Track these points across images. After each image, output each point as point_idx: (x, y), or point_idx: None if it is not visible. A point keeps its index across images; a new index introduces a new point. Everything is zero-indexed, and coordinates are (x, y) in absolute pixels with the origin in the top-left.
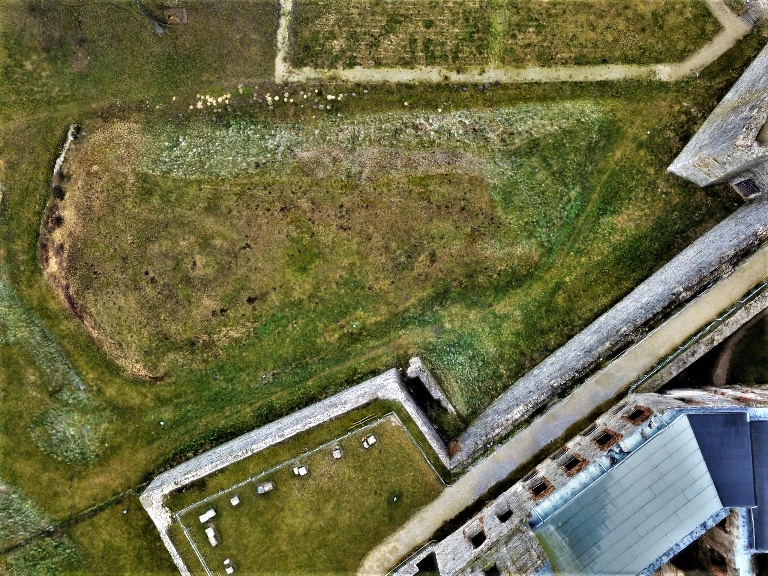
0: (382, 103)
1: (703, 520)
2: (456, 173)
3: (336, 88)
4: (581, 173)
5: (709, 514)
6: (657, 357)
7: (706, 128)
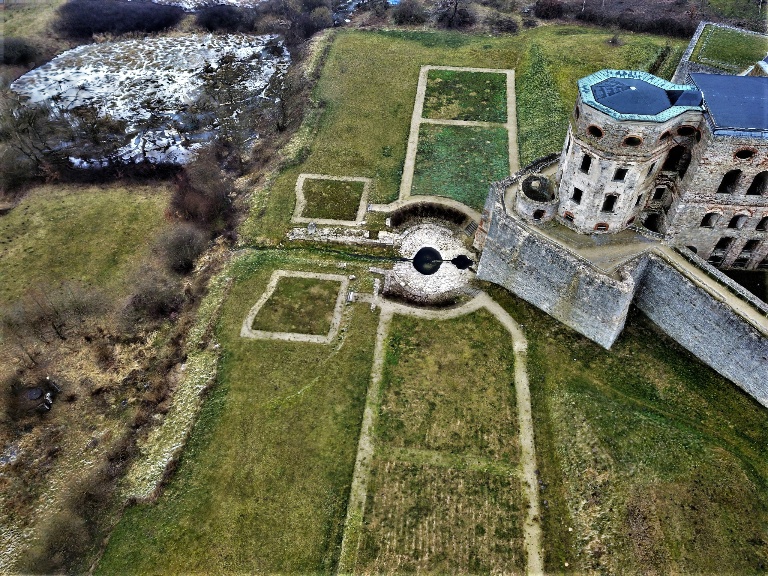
0: None
1: None
2: (656, 511)
3: None
4: None
5: None
6: None
7: (577, 320)
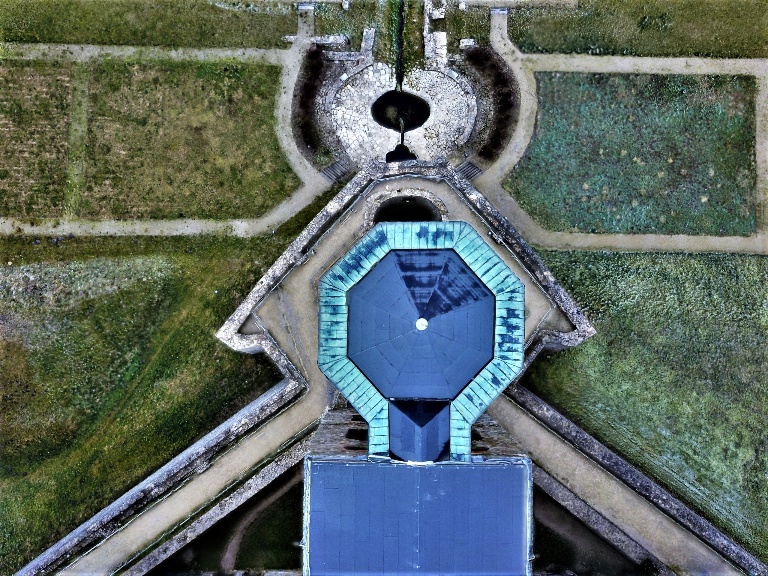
0: None
1: None
2: None
3: None
4: (141, 334)
5: None
6: (129, 553)
7: None
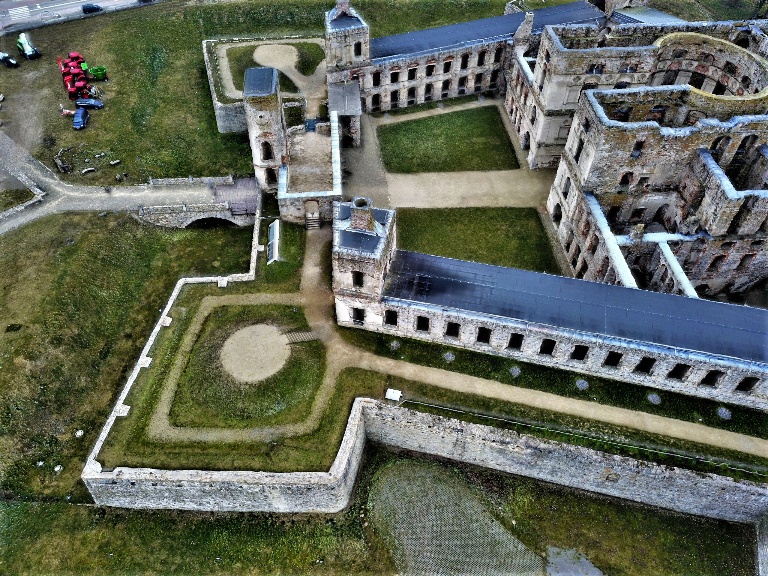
0: None
1: None
2: None
3: None
4: None
5: None
6: None
7: None
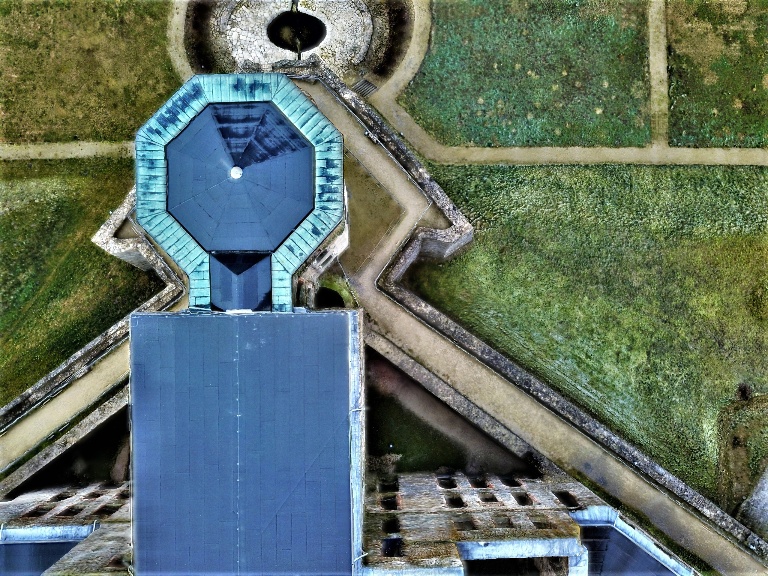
0: None
1: None
2: None
3: None
4: (34, 255)
5: None
6: (8, 460)
7: None
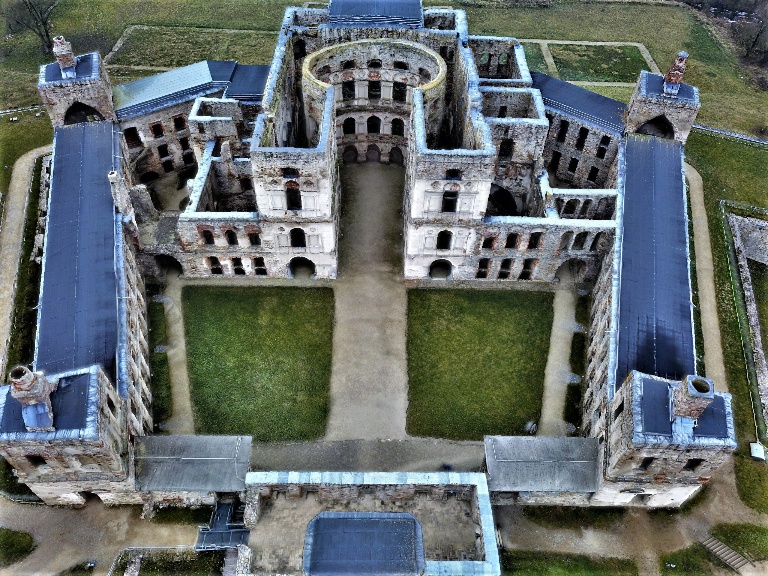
0: (148, 75)
1: (201, 84)
2: None
3: (127, 70)
4: None
5: (205, 82)
6: None
7: None
